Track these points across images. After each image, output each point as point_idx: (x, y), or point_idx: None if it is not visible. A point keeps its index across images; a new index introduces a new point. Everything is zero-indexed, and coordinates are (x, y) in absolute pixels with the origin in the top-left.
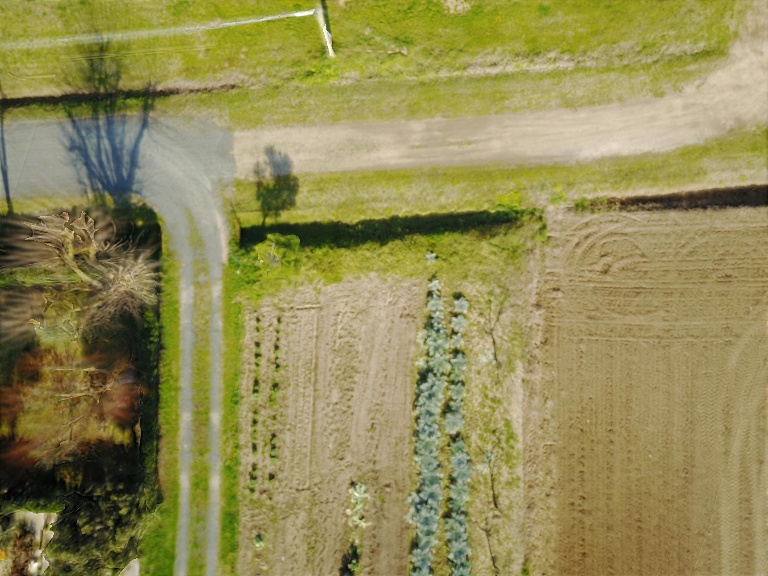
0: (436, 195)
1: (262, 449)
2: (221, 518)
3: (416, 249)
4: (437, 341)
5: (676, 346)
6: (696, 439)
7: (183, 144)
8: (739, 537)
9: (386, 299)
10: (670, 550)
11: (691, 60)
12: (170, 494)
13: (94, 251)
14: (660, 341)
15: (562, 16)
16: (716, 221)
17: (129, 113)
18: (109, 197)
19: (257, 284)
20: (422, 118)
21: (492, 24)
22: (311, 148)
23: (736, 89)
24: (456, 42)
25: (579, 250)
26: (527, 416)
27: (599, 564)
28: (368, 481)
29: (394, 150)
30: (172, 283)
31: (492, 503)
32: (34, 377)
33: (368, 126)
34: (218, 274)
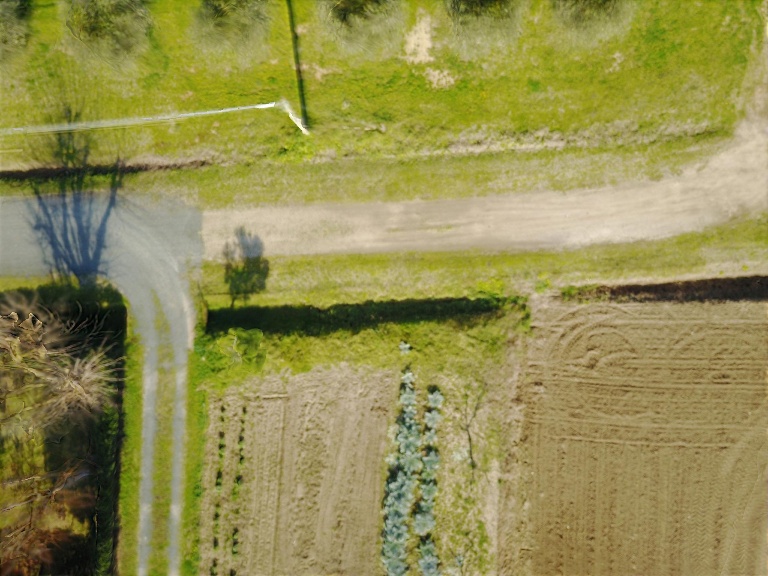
0: (412, 281)
1: (224, 544)
2: None
3: (389, 339)
4: (408, 438)
5: (666, 451)
6: (685, 552)
7: (150, 223)
8: None
9: (357, 390)
10: None
11: (691, 142)
12: None
13: (43, 352)
14: (649, 445)
15: (552, 92)
16: (714, 317)
17: (96, 190)
18: (74, 277)
19: (222, 372)
20: (399, 199)
21: (476, 100)
22: (282, 229)
23: (740, 174)
24: (437, 119)
25: (564, 342)
26: (503, 519)
27: None
28: None
29: (369, 233)
30: (136, 368)
31: None
32: None
33: (342, 207)
34: (183, 359)
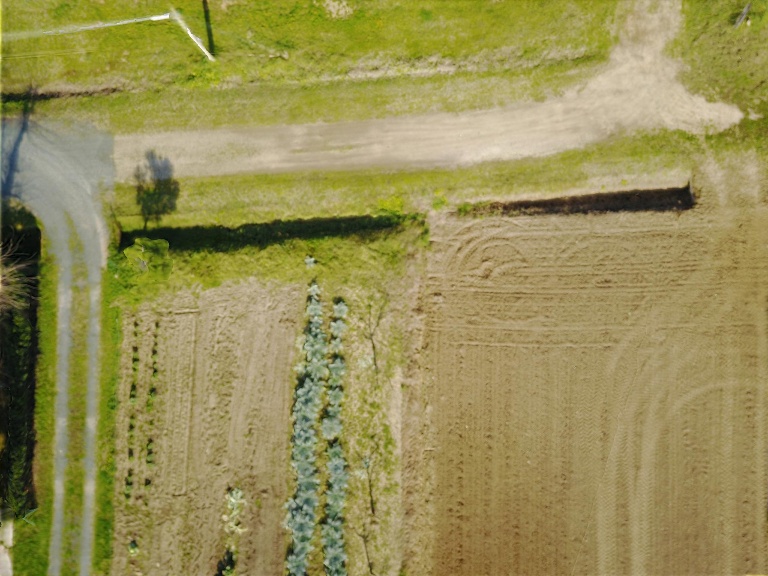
0: (317, 199)
1: (139, 454)
2: (96, 524)
3: (295, 254)
4: (314, 346)
5: (555, 351)
6: (574, 445)
7: (63, 148)
8: (616, 544)
9: (265, 304)
10: (547, 557)
11: (572, 65)
12: (45, 499)
13: None
14: (539, 346)
15: (444, 20)
16: (596, 226)
17: (9, 117)
18: None
19: (134, 288)
20: (303, 122)
21: (374, 28)
22: (192, 152)
23: (617, 94)
24: (337, 46)
25: (461, 255)
26: (406, 422)
27: (476, 571)
28: (245, 487)
29: (275, 154)
30: (50, 287)
31: (370, 509)
32: None
33: (249, 130)
34: (97, 278)
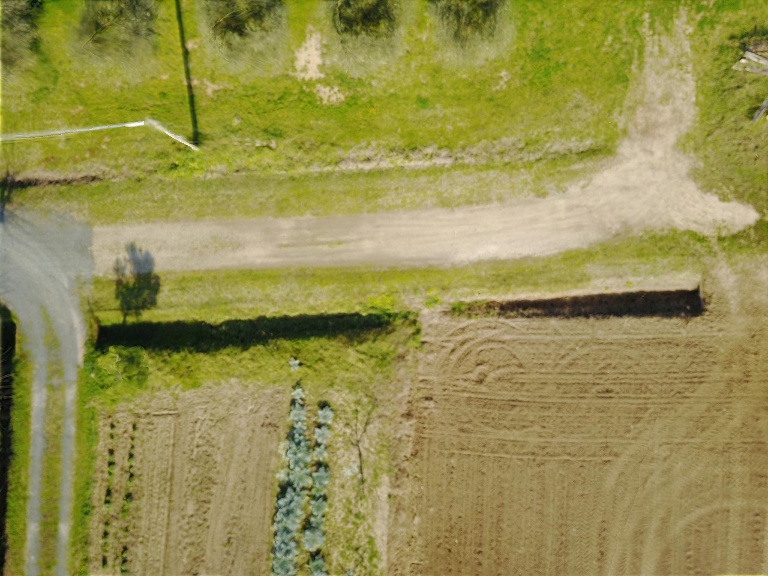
0: (303, 297)
1: (113, 562)
2: None
3: (279, 355)
4: (297, 454)
5: (552, 464)
6: (570, 564)
7: (39, 239)
8: None
9: (247, 406)
10: None
11: (576, 159)
12: None
13: None
14: (535, 458)
15: (440, 109)
16: (598, 332)
17: None
18: None
19: None
20: (290, 215)
21: (366, 117)
22: (173, 245)
23: (623, 191)
24: (327, 135)
25: (454, 357)
26: (393, 533)
27: None
28: None
29: (260, 248)
30: (24, 385)
31: None
32: None
33: (233, 223)
34: (72, 376)
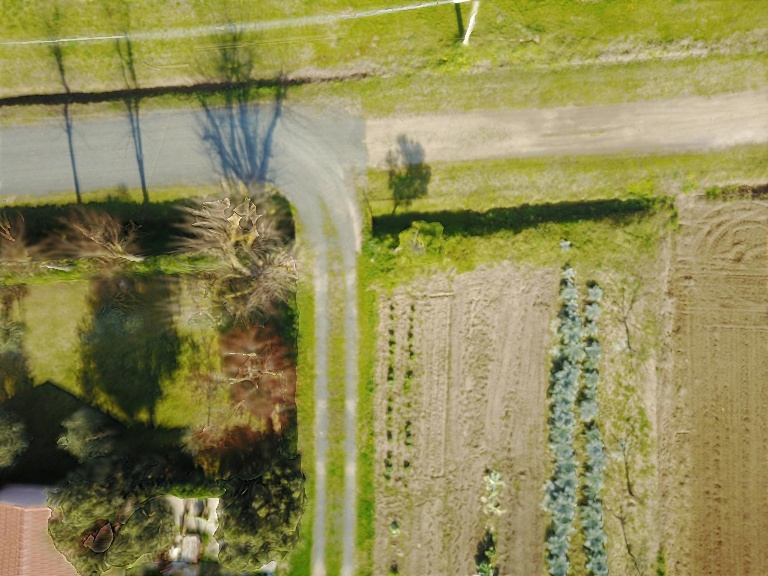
0: (568, 183)
1: (397, 436)
2: (357, 505)
3: (550, 237)
4: (573, 329)
5: None
6: None
7: (316, 133)
8: None
9: (519, 287)
10: None
11: None
12: (306, 481)
13: (254, 237)
14: None
15: (695, 3)
16: None
17: (262, 102)
18: (243, 186)
19: (392, 272)
20: (554, 106)
21: (624, 12)
22: (443, 136)
23: None
24: (588, 30)
25: (711, 238)
26: (661, 404)
27: (736, 553)
28: (503, 469)
29: (526, 138)
30: (306, 271)
31: (627, 491)
32: (171, 364)
33: (500, 114)
34: (351, 262)
